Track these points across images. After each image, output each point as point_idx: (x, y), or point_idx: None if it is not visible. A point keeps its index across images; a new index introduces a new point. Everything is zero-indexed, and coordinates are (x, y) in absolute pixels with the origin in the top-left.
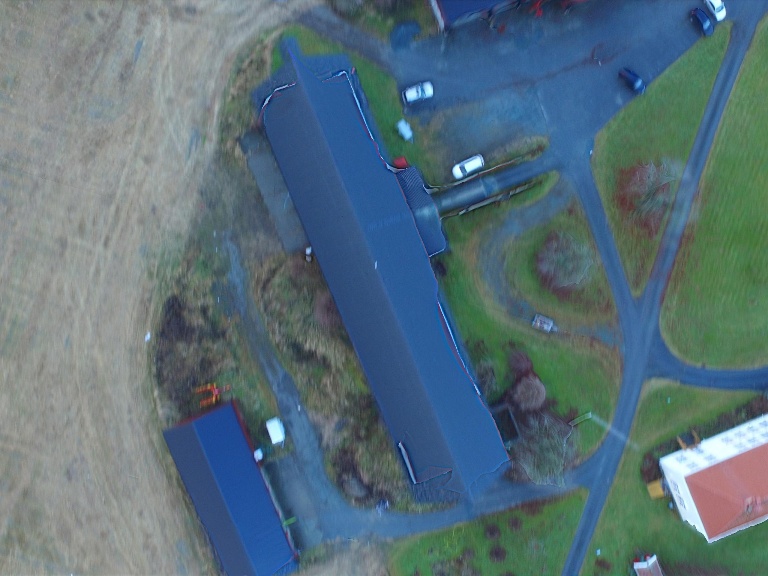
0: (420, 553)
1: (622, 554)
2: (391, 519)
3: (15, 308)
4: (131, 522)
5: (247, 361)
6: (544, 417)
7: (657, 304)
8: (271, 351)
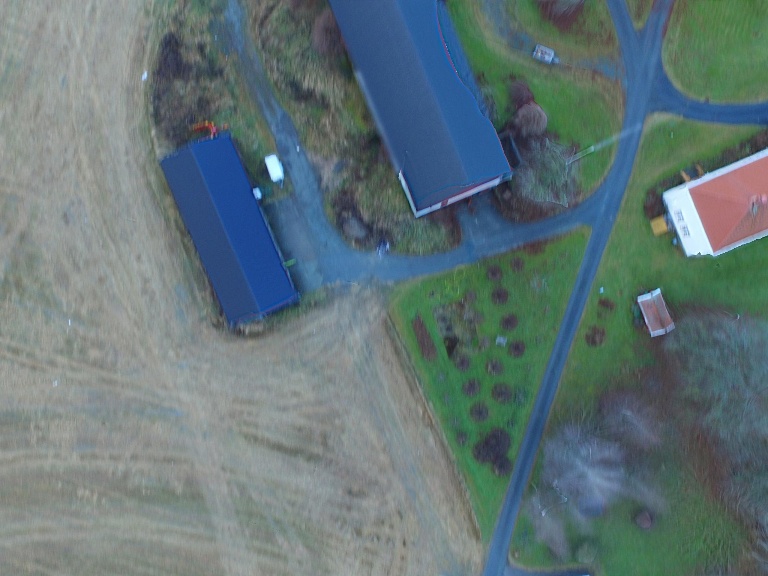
0: (421, 296)
1: (626, 293)
2: (392, 262)
3: (11, 48)
4: (129, 266)
5: (245, 100)
6: (546, 138)
7: (659, 36)
8: (269, 90)
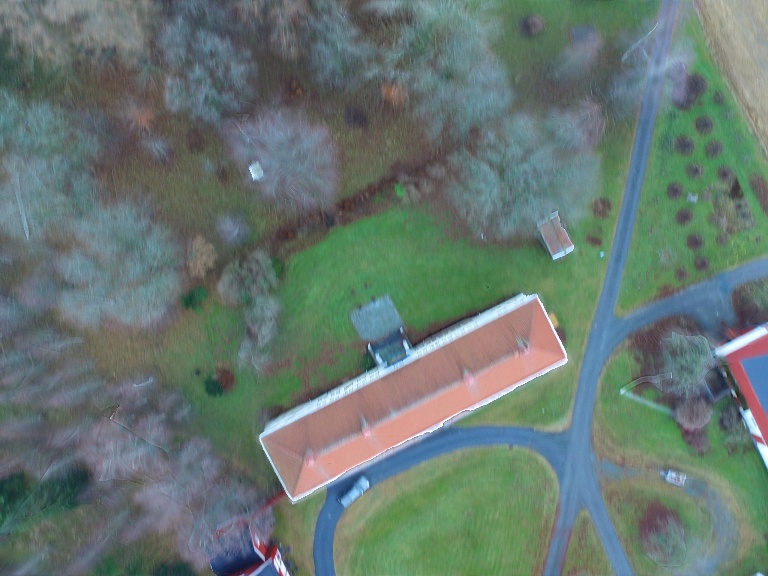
0: None
1: (577, 253)
2: None
3: None
4: None
5: None
6: None
7: (563, 504)
8: None
